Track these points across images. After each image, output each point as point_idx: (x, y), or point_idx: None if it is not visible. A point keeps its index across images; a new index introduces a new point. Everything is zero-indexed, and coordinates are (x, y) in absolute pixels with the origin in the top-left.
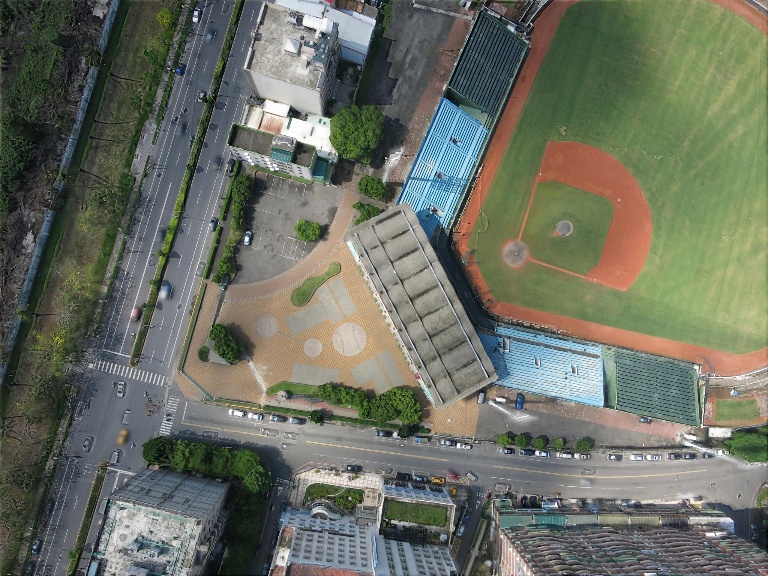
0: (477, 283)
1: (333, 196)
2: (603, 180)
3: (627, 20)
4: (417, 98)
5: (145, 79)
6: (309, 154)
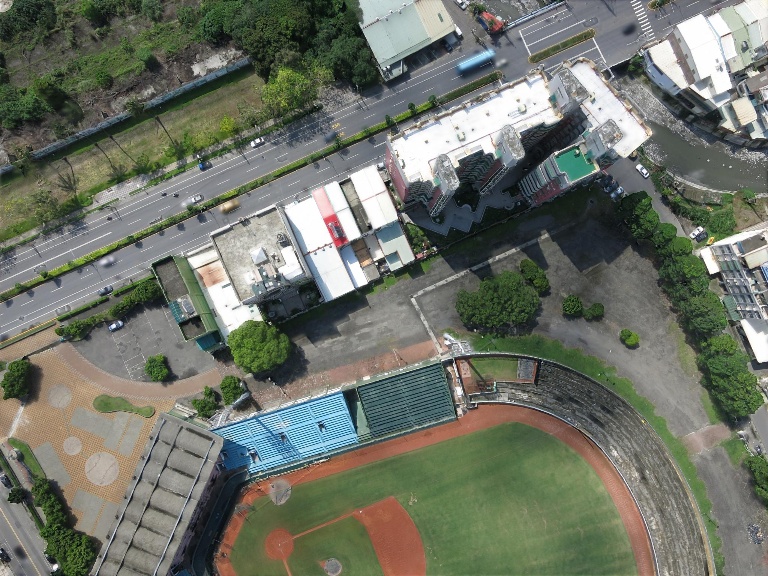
0: (230, 532)
1: (204, 363)
2: (399, 567)
3: (551, 479)
4: (339, 363)
5: (167, 151)
6: (199, 331)
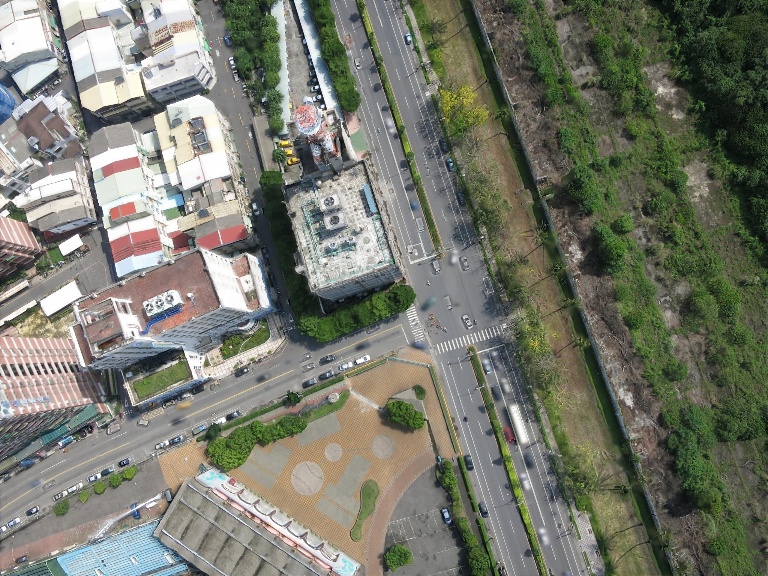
0: None
1: None
2: None
3: None
4: None
5: None
6: None
